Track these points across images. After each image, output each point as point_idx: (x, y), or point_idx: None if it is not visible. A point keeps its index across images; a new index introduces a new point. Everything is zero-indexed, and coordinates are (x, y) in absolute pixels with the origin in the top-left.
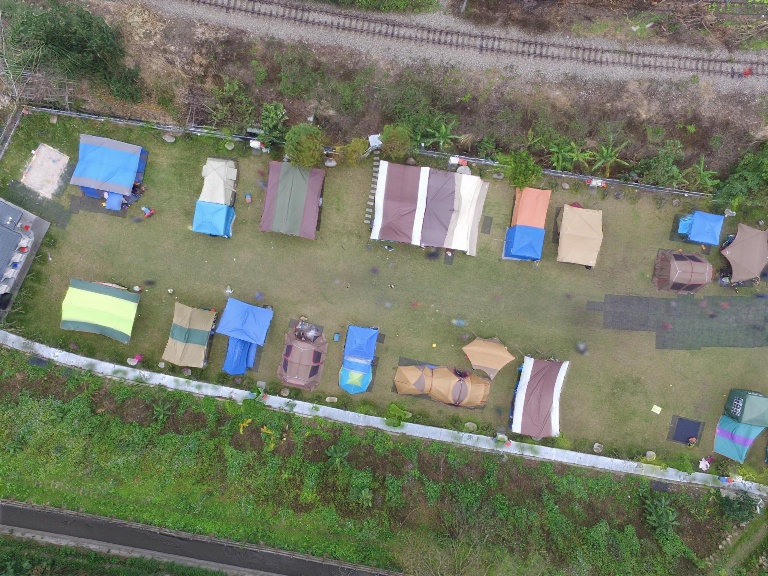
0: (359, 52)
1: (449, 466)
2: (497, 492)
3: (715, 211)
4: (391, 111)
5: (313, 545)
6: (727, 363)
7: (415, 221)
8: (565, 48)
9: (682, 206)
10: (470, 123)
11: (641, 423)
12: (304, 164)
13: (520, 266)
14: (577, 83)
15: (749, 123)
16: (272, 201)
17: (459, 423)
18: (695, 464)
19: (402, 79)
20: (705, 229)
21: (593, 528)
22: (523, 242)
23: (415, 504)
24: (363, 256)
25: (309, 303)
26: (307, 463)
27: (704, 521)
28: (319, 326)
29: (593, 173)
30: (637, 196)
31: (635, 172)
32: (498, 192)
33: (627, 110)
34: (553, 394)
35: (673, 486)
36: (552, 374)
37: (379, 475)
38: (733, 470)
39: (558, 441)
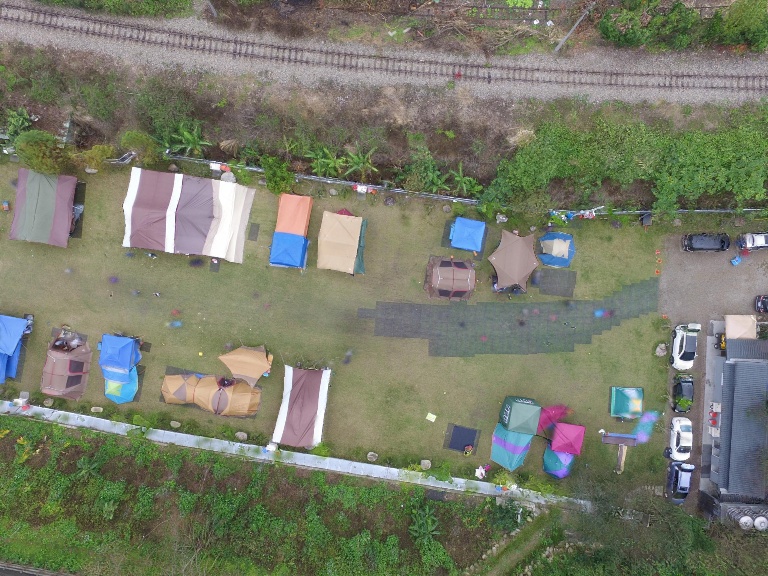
0: (110, 57)
1: (213, 476)
2: (259, 503)
3: (486, 217)
4: (147, 117)
5: (50, 559)
6: (501, 370)
7: (166, 228)
8: (320, 53)
9: (453, 212)
10: (231, 129)
11: (416, 431)
12: (43, 171)
13: (288, 273)
14: (334, 89)
15: (508, 129)
16: (21, 209)
17: (229, 433)
18: (471, 472)
19: (155, 85)
20: (464, 235)
21: (353, 539)
22: (279, 249)
23: (166, 516)
24: (126, 264)
25: (72, 312)
26: (57, 475)
27: (475, 530)
28: (83, 335)
29: (365, 179)
30: (407, 202)
31: (399, 178)
32: (265, 199)
33: (385, 116)
34: (318, 403)
35: (449, 495)
36: (313, 383)
37: (132, 487)
38: (510, 478)
39: (331, 450)
